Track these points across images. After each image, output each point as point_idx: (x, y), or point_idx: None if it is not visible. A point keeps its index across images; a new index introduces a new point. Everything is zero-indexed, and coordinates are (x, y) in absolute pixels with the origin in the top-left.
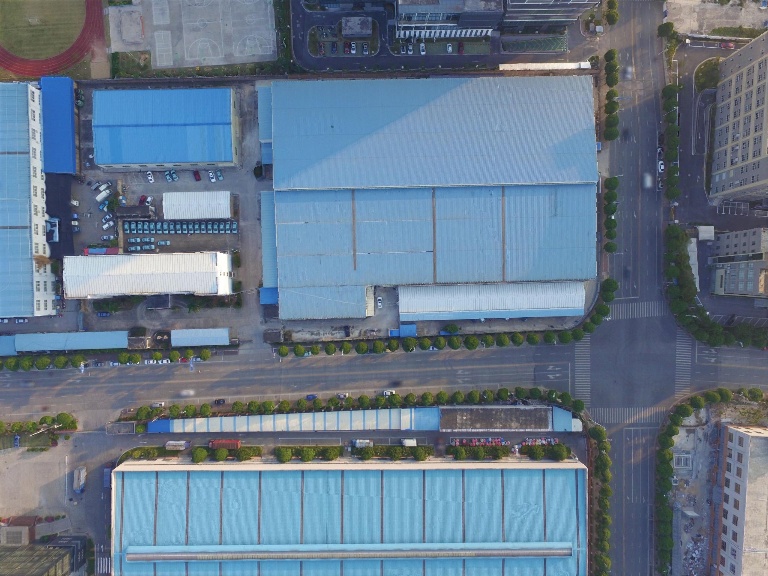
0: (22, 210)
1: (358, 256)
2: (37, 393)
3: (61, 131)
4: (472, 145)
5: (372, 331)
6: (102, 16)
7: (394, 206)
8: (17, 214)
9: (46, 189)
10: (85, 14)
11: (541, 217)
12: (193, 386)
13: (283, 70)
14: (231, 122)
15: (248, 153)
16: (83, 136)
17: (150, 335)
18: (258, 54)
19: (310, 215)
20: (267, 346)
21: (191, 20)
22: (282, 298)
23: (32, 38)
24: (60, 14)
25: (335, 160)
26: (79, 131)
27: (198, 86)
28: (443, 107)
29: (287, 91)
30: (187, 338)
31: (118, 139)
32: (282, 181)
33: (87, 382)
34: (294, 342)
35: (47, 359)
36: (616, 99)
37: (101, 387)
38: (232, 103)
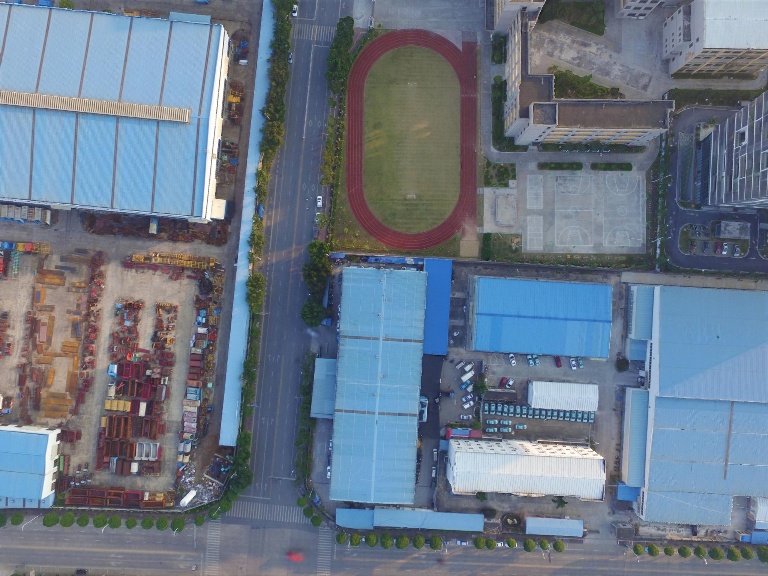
0: (412, 398)
1: (730, 466)
2: (382, 565)
3: (439, 313)
4: None
5: (720, 532)
6: (475, 195)
7: None
8: (407, 401)
9: None
10: (459, 192)
11: None
12: (536, 571)
13: (652, 264)
14: (611, 320)
15: None
16: None
17: (499, 517)
18: (627, 246)
19: (687, 422)
20: (613, 538)
21: (564, 207)
22: (649, 501)
23: (406, 212)
24: (435, 190)
25: (720, 371)
26: None
27: (565, 272)
28: None
29: (674, 297)
30: (542, 527)
31: (499, 328)
32: (667, 388)
33: (432, 558)
34: (643, 538)
35: (407, 538)
36: None
37: (446, 564)
38: (611, 300)
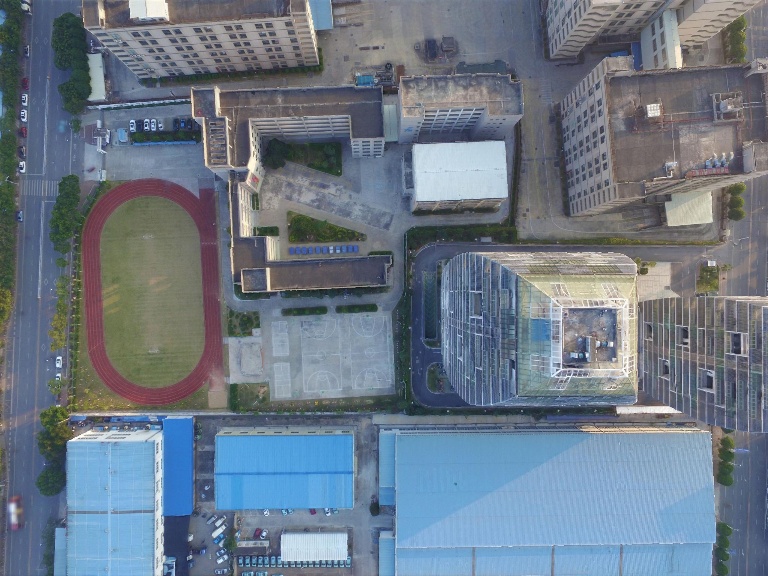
0: (145, 569)
1: None
2: None
3: (181, 473)
4: (593, 504)
5: None
6: (221, 345)
7: (514, 562)
8: (140, 573)
9: (164, 531)
10: (204, 342)
11: (657, 573)
12: None
13: None
14: (353, 471)
15: (363, 486)
16: (199, 467)
17: None
18: (376, 388)
19: (430, 570)
20: None
21: (310, 352)
22: None
23: (150, 366)
24: (179, 342)
25: (458, 519)
26: (196, 463)
27: (315, 418)
28: (565, 464)
29: (411, 446)
30: None
31: (239, 486)
32: (405, 540)
33: None
34: None
35: None
36: (732, 451)
37: None
38: None
